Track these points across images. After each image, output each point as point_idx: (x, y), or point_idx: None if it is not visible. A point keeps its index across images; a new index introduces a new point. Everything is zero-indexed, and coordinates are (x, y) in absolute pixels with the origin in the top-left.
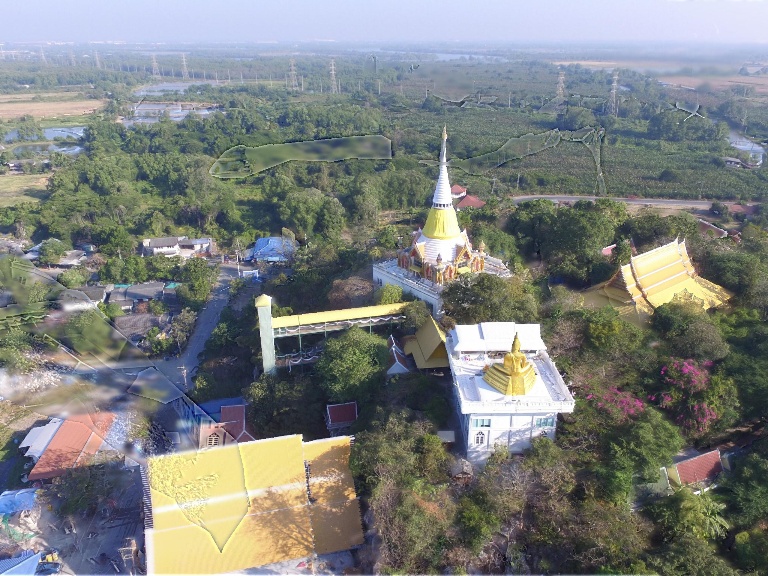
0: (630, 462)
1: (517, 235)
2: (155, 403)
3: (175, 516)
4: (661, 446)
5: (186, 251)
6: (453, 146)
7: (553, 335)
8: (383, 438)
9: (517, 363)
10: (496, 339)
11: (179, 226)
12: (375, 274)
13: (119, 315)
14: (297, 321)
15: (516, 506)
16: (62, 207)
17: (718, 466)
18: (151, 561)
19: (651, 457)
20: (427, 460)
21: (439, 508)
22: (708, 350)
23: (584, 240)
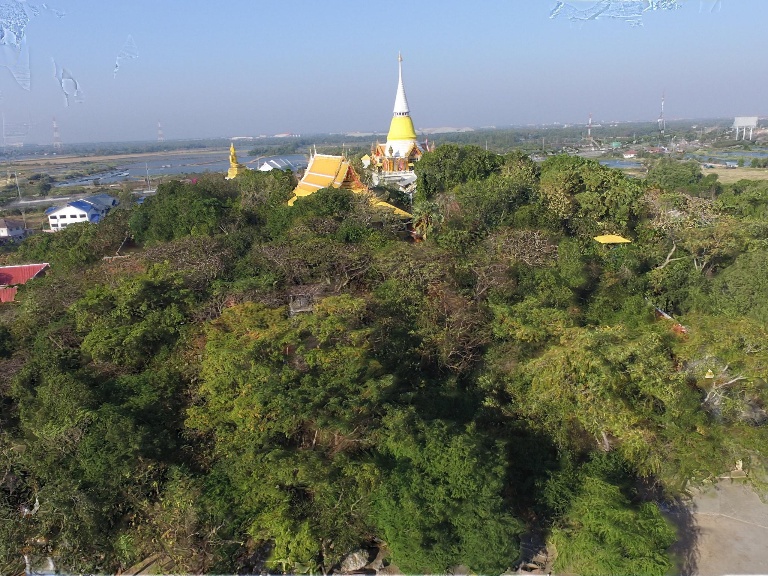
0: None
1: None
2: (116, 68)
3: None
4: None
5: None
6: None
7: None
8: None
9: None
10: None
11: None
12: None
13: None
14: None
15: None
16: None
17: None
18: None
19: None
20: None
21: None
22: None
23: None
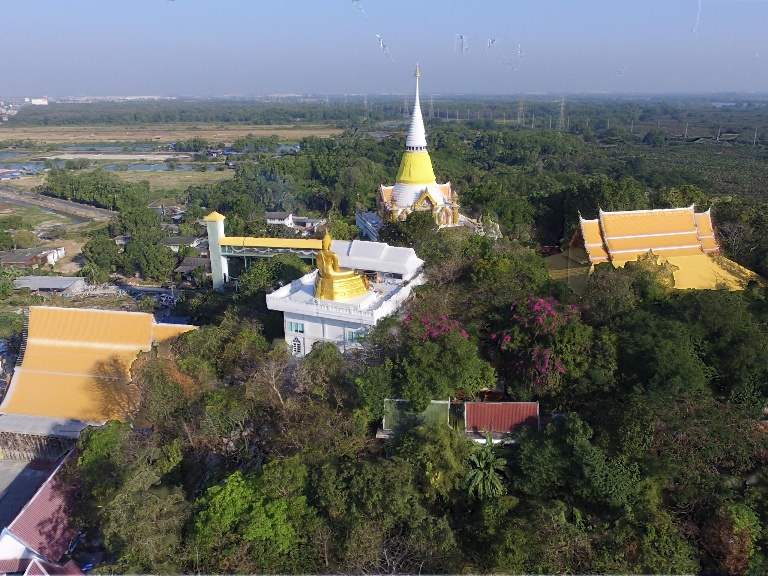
0: (388, 376)
1: (538, 206)
2: None
3: (39, 361)
4: (437, 369)
5: (299, 227)
6: (636, 169)
7: (433, 265)
8: (211, 328)
9: (327, 263)
10: (360, 257)
11: (311, 210)
12: (357, 222)
13: (193, 256)
14: (242, 242)
15: (252, 394)
16: (229, 188)
17: (532, 422)
18: (10, 393)
19: (415, 376)
20: (225, 348)
21: (193, 384)
22: (599, 299)
23: (598, 209)
